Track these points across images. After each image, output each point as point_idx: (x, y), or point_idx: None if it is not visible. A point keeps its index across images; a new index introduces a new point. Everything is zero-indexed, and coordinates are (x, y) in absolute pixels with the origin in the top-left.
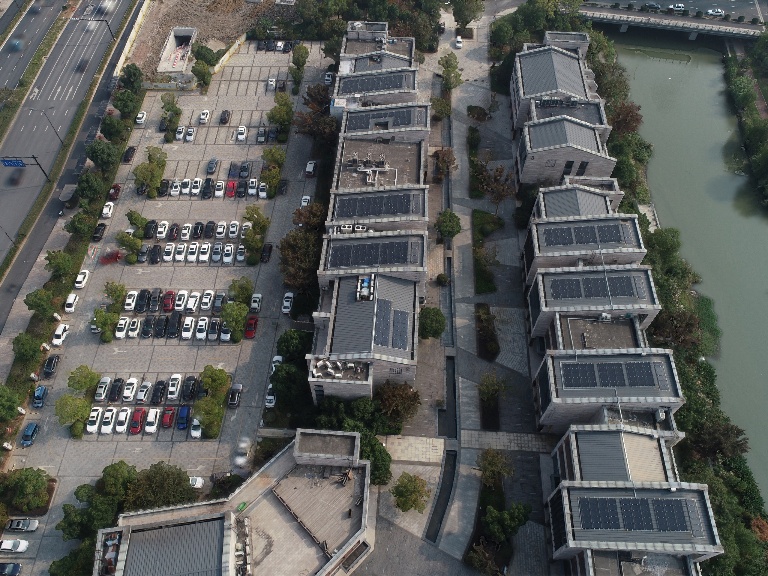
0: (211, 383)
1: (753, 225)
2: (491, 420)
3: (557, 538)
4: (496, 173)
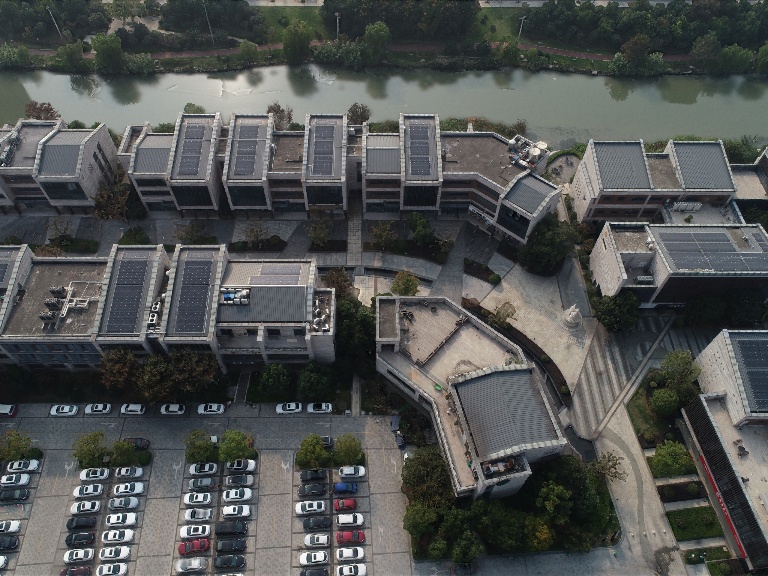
0: (320, 445)
1: (164, 87)
2: (339, 244)
3: (430, 200)
4: (101, 200)
